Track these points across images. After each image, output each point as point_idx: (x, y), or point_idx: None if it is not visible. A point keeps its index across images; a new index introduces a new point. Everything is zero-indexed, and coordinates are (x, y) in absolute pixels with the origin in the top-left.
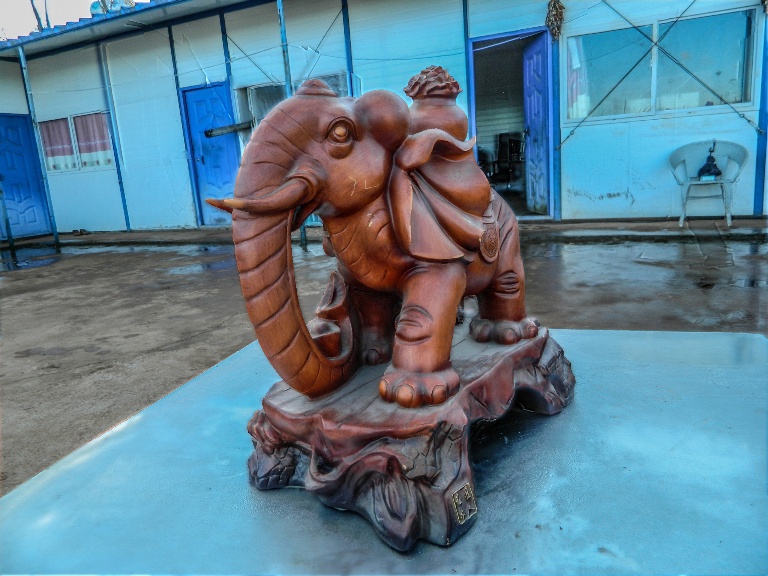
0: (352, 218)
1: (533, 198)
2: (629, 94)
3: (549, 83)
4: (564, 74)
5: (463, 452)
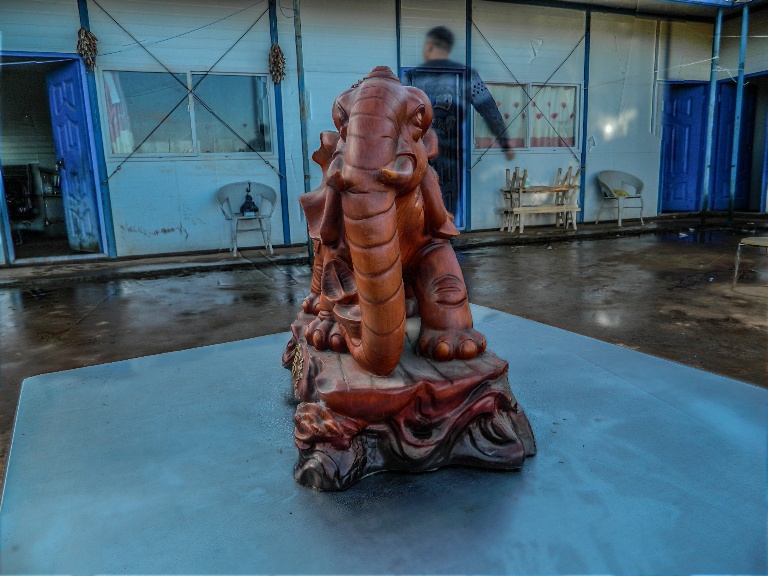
0: (404, 199)
1: (77, 236)
2: (172, 135)
3: (87, 114)
4: (103, 107)
5: None
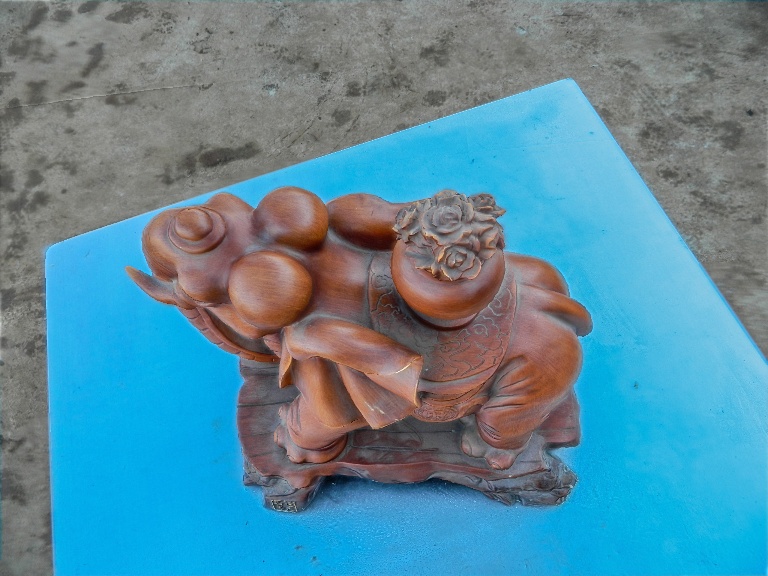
0: None
1: None
2: None
3: None
4: None
5: (305, 488)
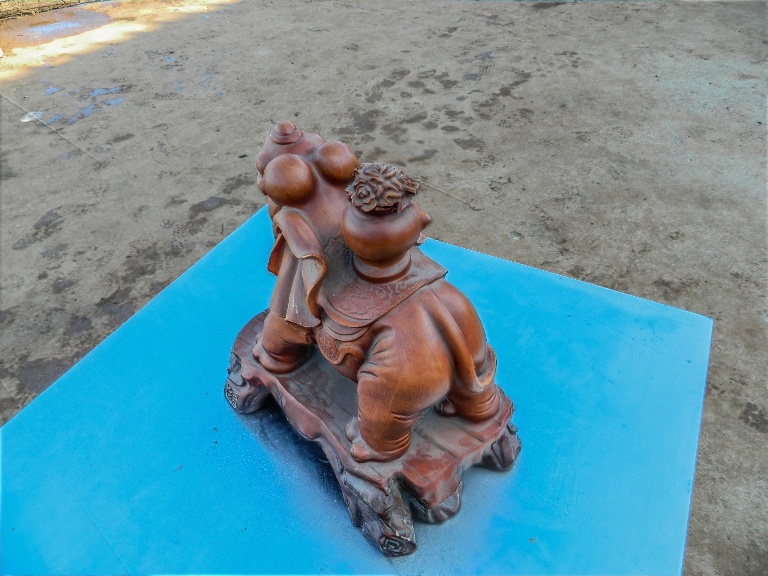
0: None
1: None
2: None
3: None
4: None
5: (249, 388)
